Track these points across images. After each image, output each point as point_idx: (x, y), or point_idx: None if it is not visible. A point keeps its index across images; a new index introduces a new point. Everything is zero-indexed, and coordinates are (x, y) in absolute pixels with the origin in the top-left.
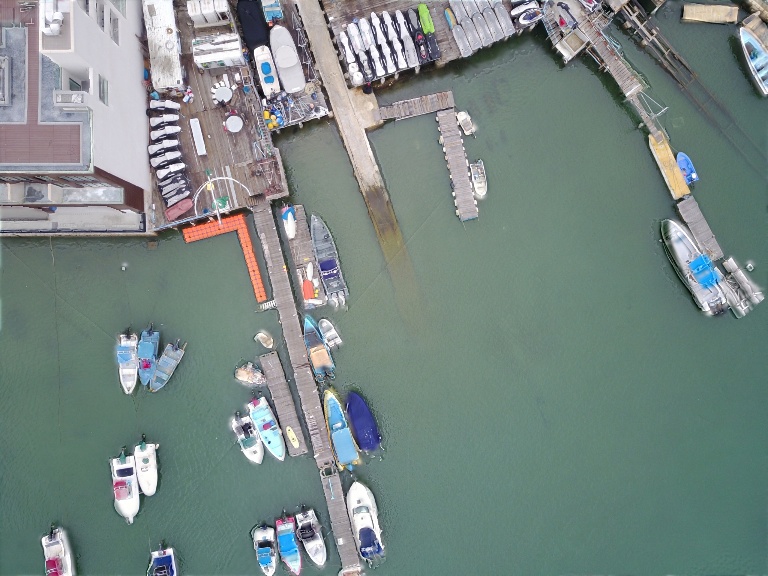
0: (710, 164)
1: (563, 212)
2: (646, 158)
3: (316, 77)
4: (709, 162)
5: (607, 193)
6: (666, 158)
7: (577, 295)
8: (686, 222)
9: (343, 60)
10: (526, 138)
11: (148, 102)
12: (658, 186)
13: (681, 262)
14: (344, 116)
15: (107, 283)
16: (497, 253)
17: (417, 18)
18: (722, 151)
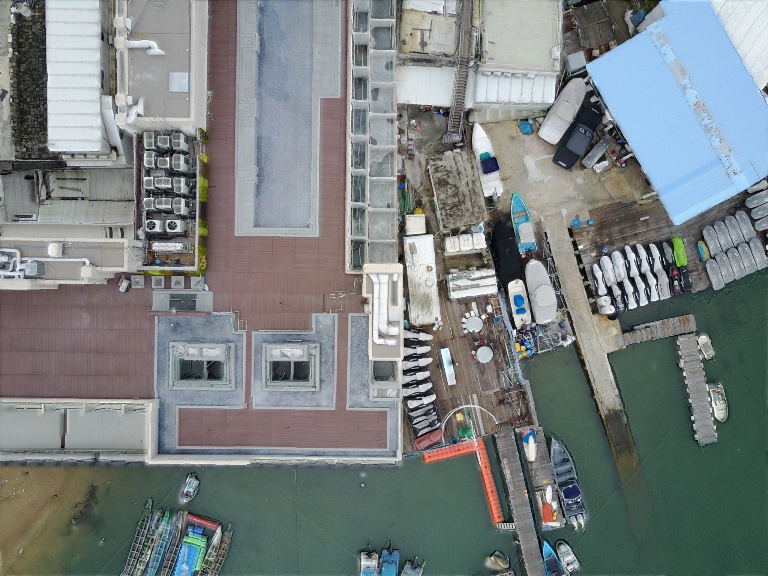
0: None
1: None
2: None
3: (565, 307)
4: None
5: None
6: None
7: None
8: None
9: (588, 285)
10: (764, 360)
11: None
12: None
13: None
14: (587, 341)
15: (345, 498)
16: (731, 475)
17: (672, 253)
18: None
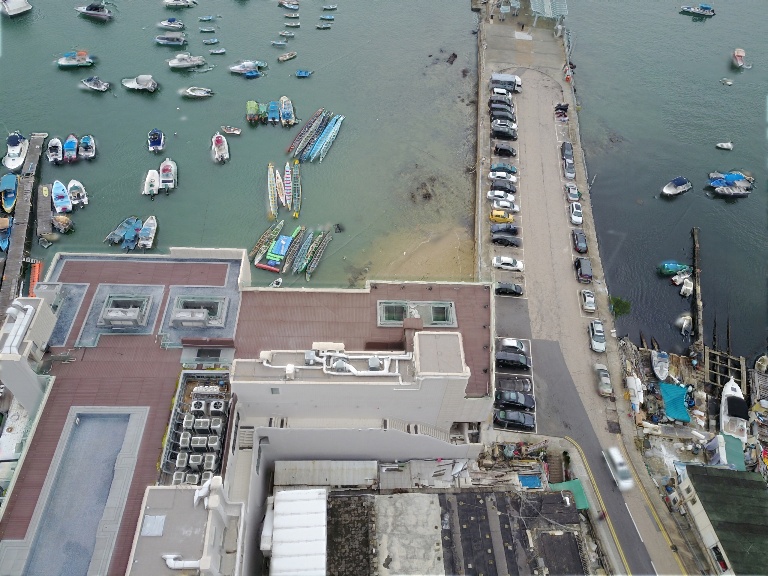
0: None
1: None
2: None
3: None
4: None
5: None
6: None
7: None
8: None
9: None
10: None
11: None
12: None
13: None
14: None
15: None
16: None
17: None
18: None
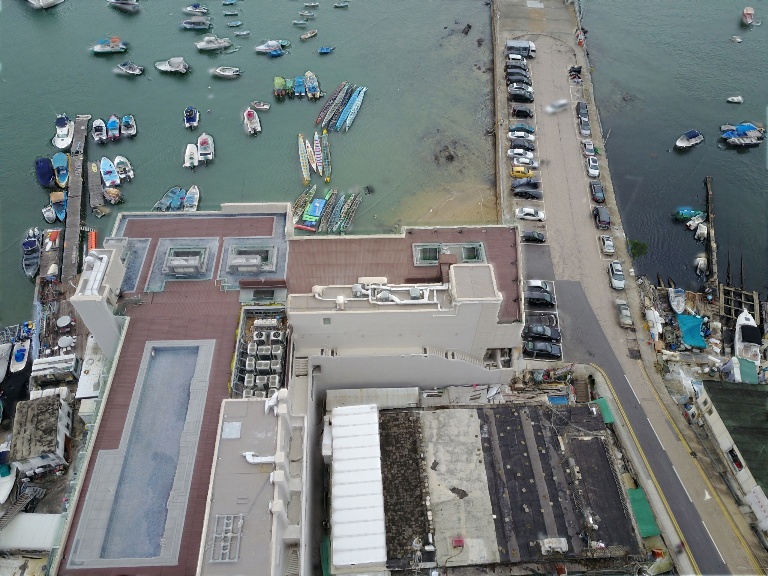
0: None
1: None
2: None
3: None
4: None
5: None
6: None
7: None
8: None
9: None
10: None
11: None
12: None
13: None
14: None
15: None
16: None
17: None
18: None
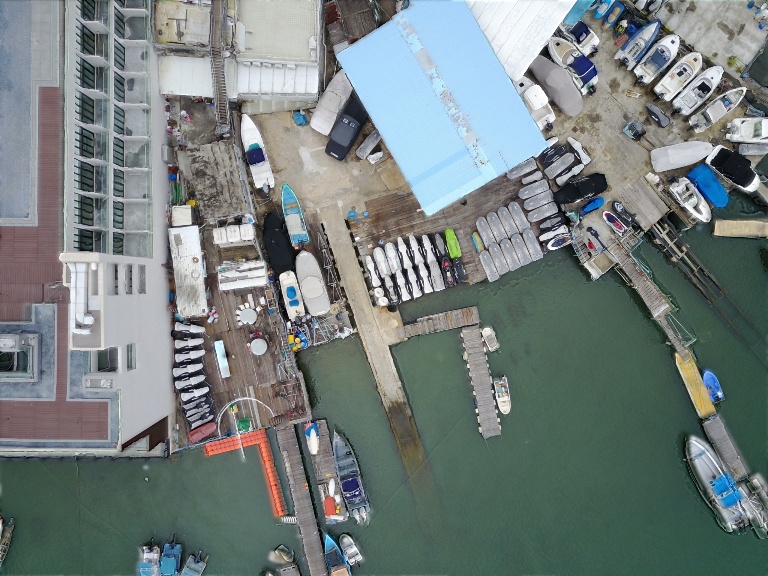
0: (737, 384)
1: (586, 426)
2: (672, 373)
3: (341, 298)
4: (736, 382)
5: (631, 406)
6: (693, 377)
7: (598, 510)
8: (711, 442)
9: (368, 277)
10: (551, 352)
11: (173, 323)
12: (683, 401)
13: (705, 484)
14: (368, 333)
15: (130, 492)
16: (519, 467)
17: (444, 244)
18: (750, 367)
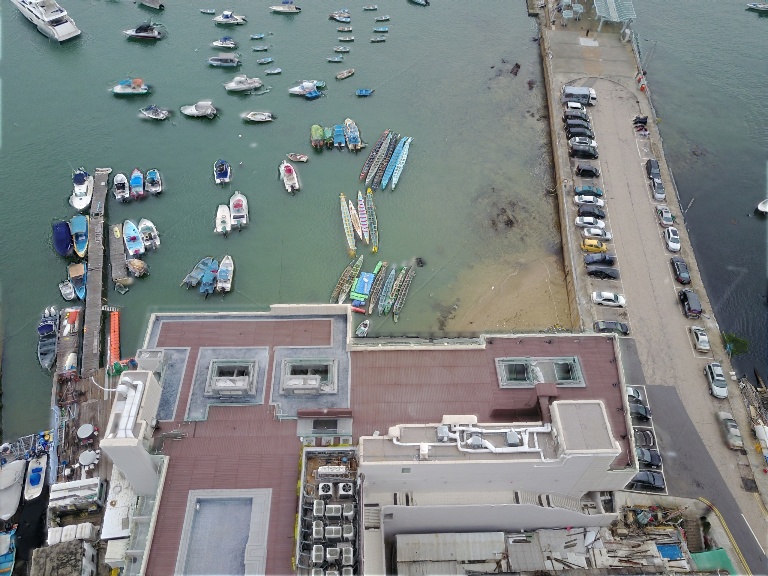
0: None
1: None
2: None
3: None
4: None
5: None
6: None
7: None
8: None
9: None
10: None
11: None
12: None
13: None
14: None
15: None
16: None
17: None
18: None
